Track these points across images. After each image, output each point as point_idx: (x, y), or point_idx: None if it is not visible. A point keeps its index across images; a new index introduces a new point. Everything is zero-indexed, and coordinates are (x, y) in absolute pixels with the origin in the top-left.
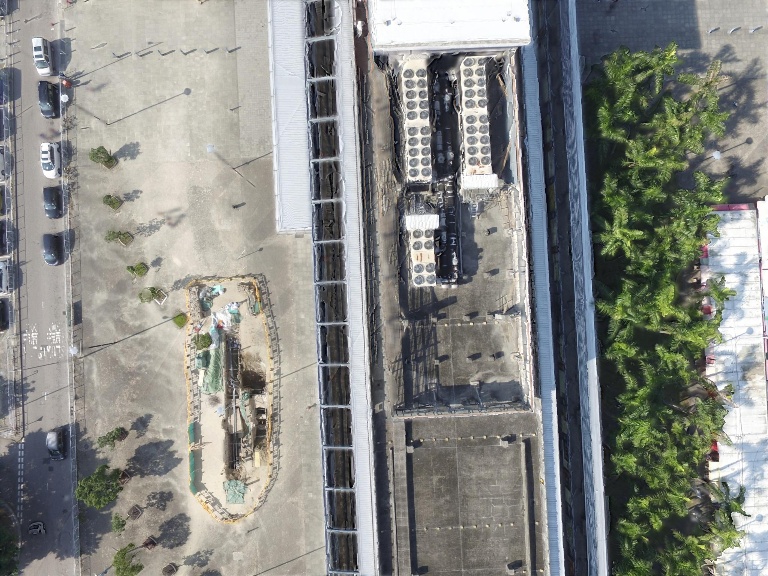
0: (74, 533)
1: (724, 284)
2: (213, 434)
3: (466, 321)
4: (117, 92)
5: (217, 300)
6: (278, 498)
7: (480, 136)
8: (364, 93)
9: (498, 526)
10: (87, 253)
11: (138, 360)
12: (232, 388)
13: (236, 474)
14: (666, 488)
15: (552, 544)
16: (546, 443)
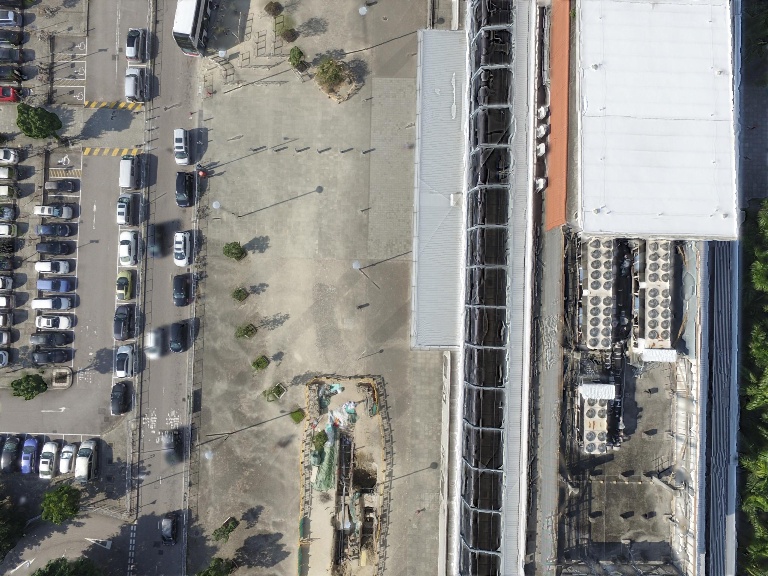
0: None
1: None
2: (322, 530)
3: (621, 479)
4: (250, 185)
5: (335, 398)
6: None
7: (662, 310)
8: (536, 246)
9: None
10: (210, 342)
11: (253, 452)
12: (343, 485)
13: (341, 571)
14: None
15: None
16: None
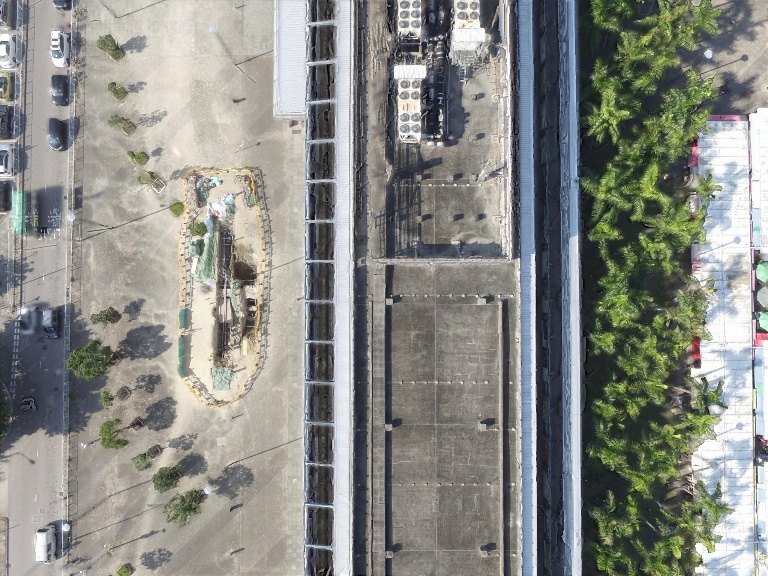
0: (64, 409)
1: None
2: (203, 321)
3: (450, 182)
4: None
5: (213, 191)
6: (263, 387)
7: None
8: None
9: (473, 383)
10: (90, 141)
11: (134, 246)
12: (224, 278)
13: (224, 362)
14: (645, 378)
15: (525, 405)
16: (523, 305)
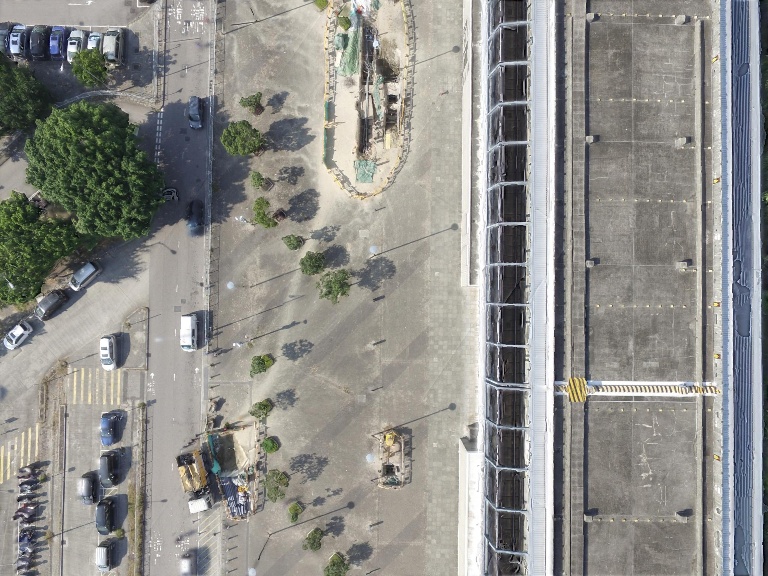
0: (208, 197)
1: None
2: (346, 114)
3: None
4: None
5: None
6: (406, 180)
7: None
8: None
9: (669, 102)
10: None
11: (278, 40)
12: (366, 74)
13: (365, 157)
14: None
15: None
16: None
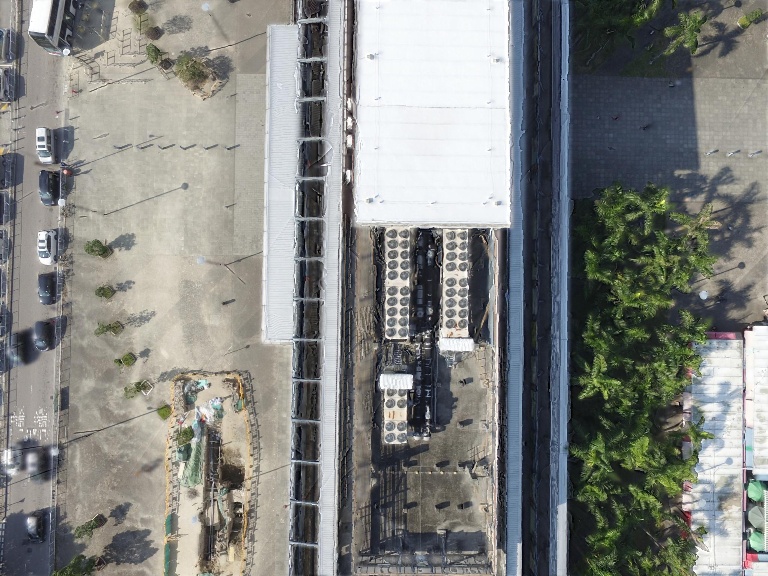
0: None
1: (703, 425)
2: (190, 526)
3: None
4: (116, 183)
5: (201, 394)
6: None
7: (459, 299)
8: (349, 237)
9: None
10: (77, 340)
11: (121, 449)
12: (211, 481)
13: (210, 566)
14: None
15: None
16: None
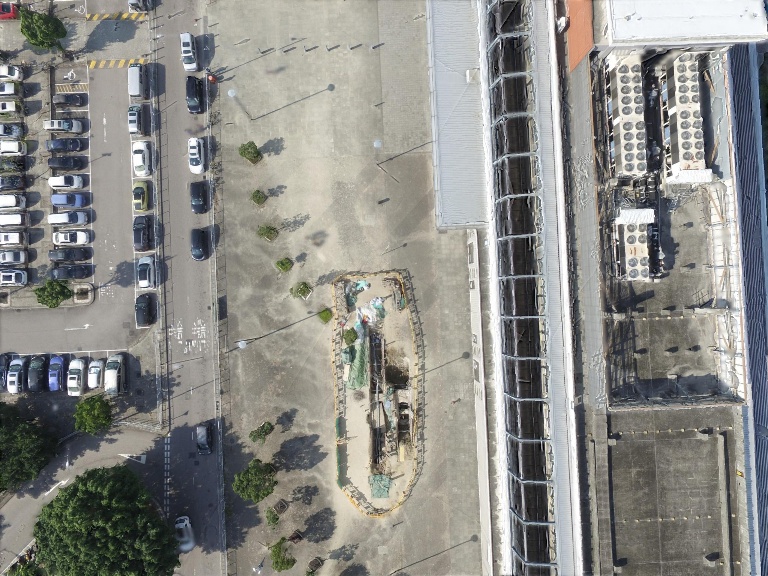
0: (222, 527)
1: None
2: (358, 429)
3: (663, 315)
4: (261, 88)
5: (361, 295)
6: (423, 492)
7: (695, 131)
8: (562, 88)
9: (695, 518)
10: (232, 248)
11: (283, 355)
12: (376, 383)
13: (380, 469)
14: None
15: None
16: None
